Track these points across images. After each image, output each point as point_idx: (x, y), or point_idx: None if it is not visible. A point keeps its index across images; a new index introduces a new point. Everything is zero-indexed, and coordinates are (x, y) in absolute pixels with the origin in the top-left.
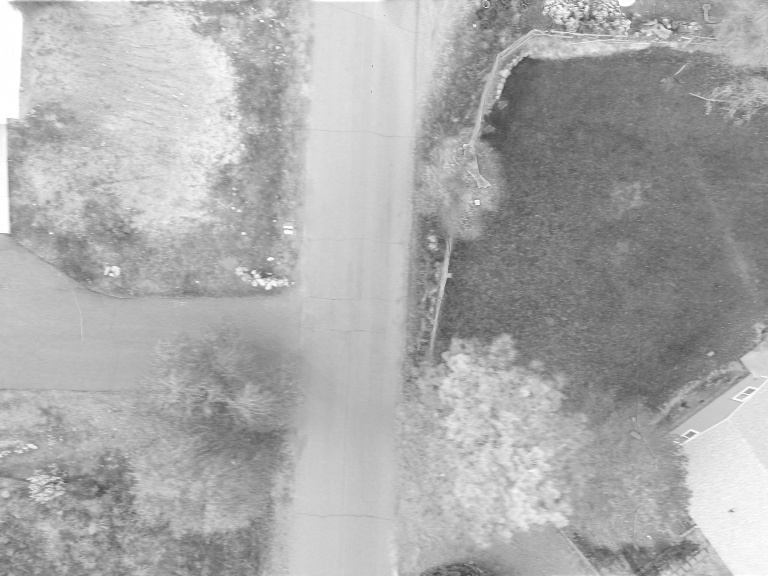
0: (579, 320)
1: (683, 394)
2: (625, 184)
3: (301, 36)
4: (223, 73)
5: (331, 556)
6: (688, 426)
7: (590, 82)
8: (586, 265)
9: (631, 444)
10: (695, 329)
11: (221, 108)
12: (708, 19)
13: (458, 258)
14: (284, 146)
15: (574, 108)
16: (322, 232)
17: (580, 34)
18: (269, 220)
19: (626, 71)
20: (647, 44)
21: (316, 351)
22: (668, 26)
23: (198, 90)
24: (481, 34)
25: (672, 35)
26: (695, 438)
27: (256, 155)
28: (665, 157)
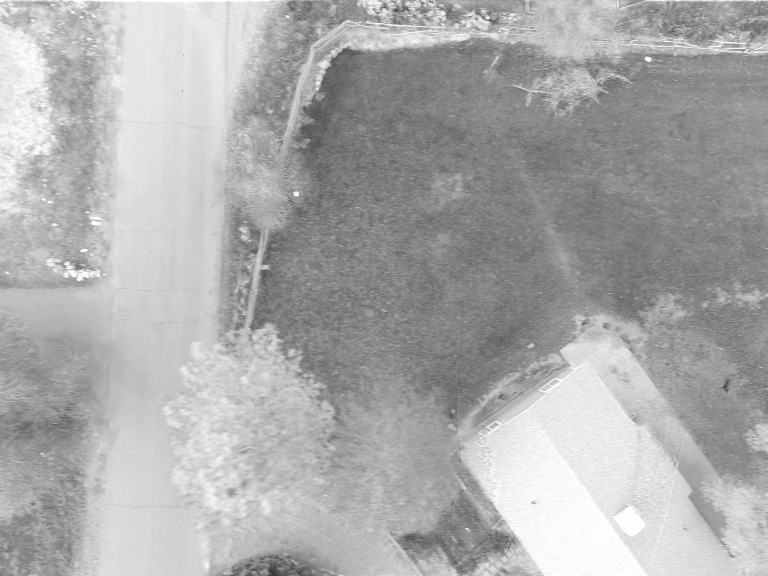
0: (399, 312)
1: (502, 386)
2: (446, 176)
3: (112, 27)
4: (33, 64)
5: (142, 547)
6: (495, 418)
7: (411, 73)
8: (406, 257)
9: (444, 436)
10: (515, 321)
11: (31, 99)
12: (529, 10)
13: (276, 250)
14: (96, 137)
15: (395, 100)
16: (134, 223)
17: (399, 25)
18: (82, 211)
19: (448, 62)
20: (467, 35)
21: (128, 342)
22: (487, 17)
23: (8, 81)
24: (295, 25)
25: (491, 26)
26: (497, 429)
27: (67, 146)
28: (487, 149)
